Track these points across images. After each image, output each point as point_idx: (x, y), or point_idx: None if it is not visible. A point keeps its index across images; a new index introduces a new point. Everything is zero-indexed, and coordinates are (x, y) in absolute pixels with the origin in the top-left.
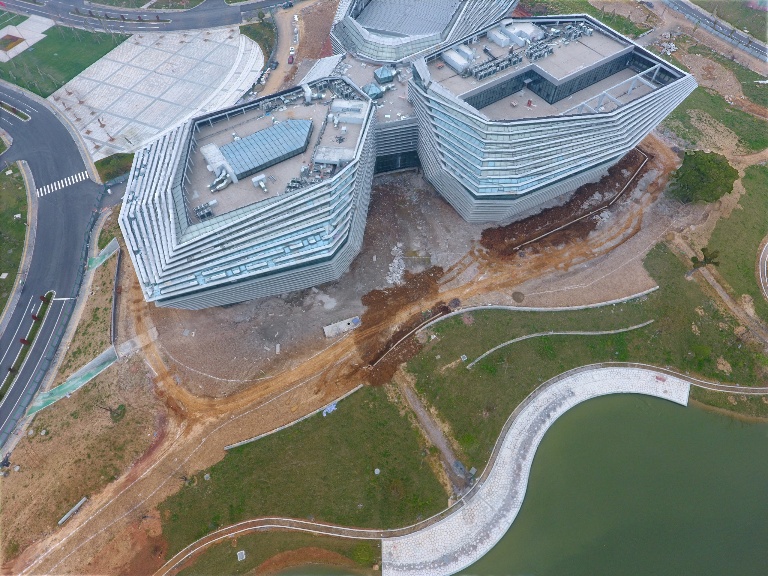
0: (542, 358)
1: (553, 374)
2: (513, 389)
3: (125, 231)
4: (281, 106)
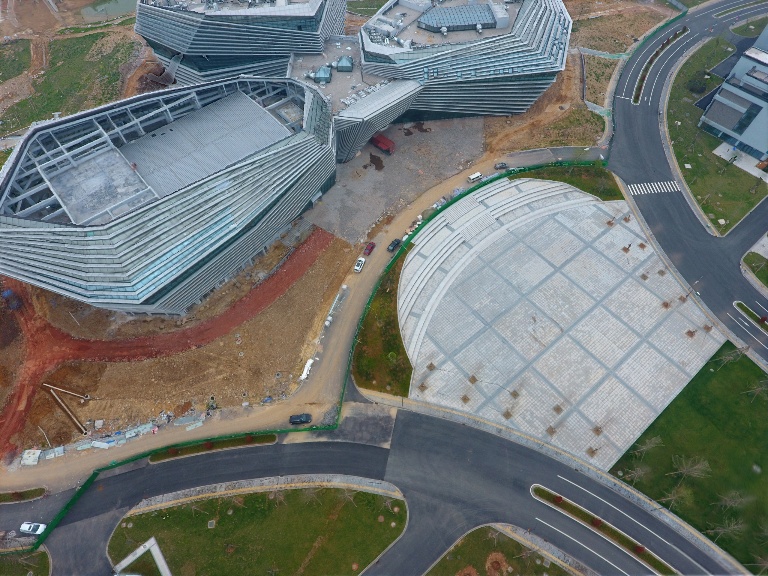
0: (351, 4)
1: (351, 1)
2: (375, 1)
3: (567, 14)
4: None
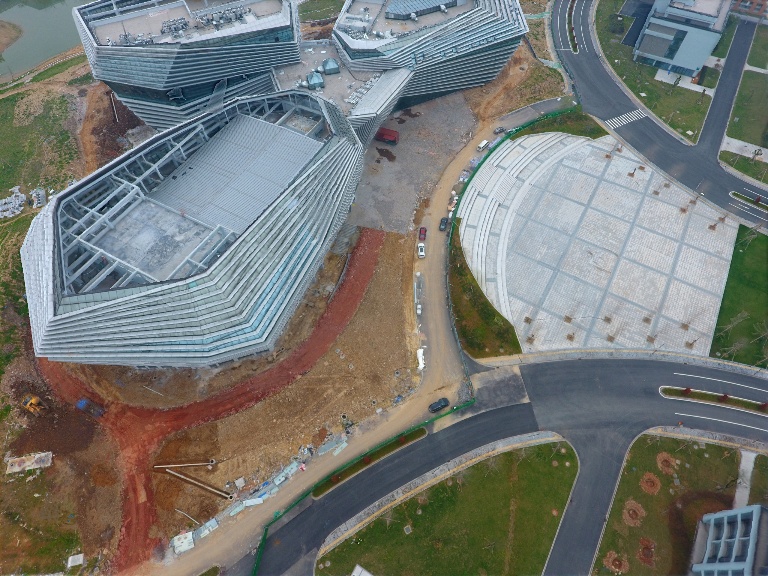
0: None
1: None
2: None
3: None
4: (412, 33)
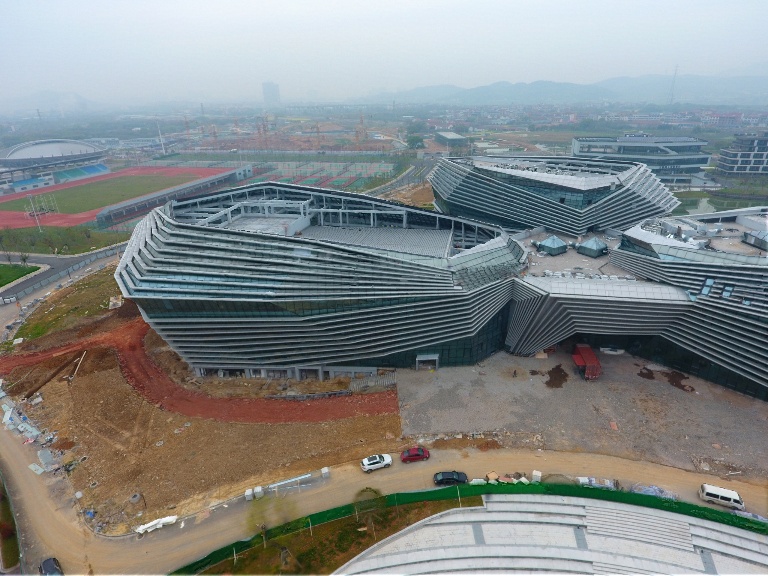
0: None
1: None
2: None
3: None
4: None
